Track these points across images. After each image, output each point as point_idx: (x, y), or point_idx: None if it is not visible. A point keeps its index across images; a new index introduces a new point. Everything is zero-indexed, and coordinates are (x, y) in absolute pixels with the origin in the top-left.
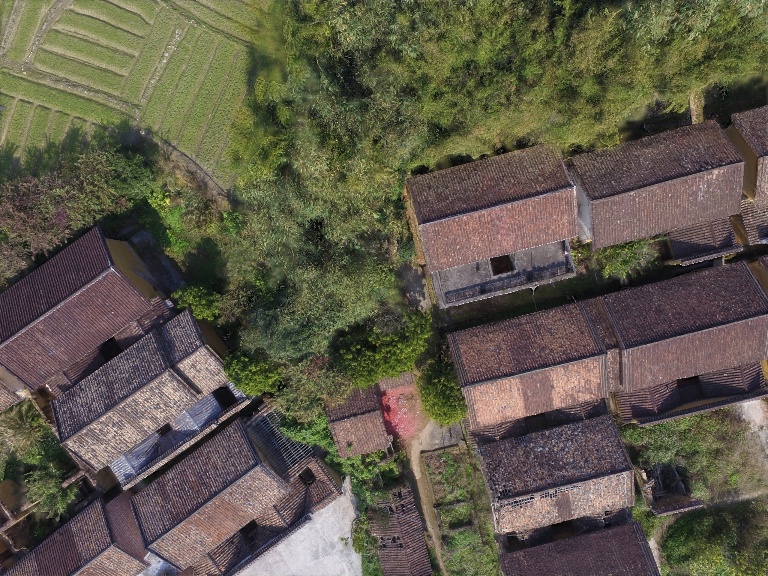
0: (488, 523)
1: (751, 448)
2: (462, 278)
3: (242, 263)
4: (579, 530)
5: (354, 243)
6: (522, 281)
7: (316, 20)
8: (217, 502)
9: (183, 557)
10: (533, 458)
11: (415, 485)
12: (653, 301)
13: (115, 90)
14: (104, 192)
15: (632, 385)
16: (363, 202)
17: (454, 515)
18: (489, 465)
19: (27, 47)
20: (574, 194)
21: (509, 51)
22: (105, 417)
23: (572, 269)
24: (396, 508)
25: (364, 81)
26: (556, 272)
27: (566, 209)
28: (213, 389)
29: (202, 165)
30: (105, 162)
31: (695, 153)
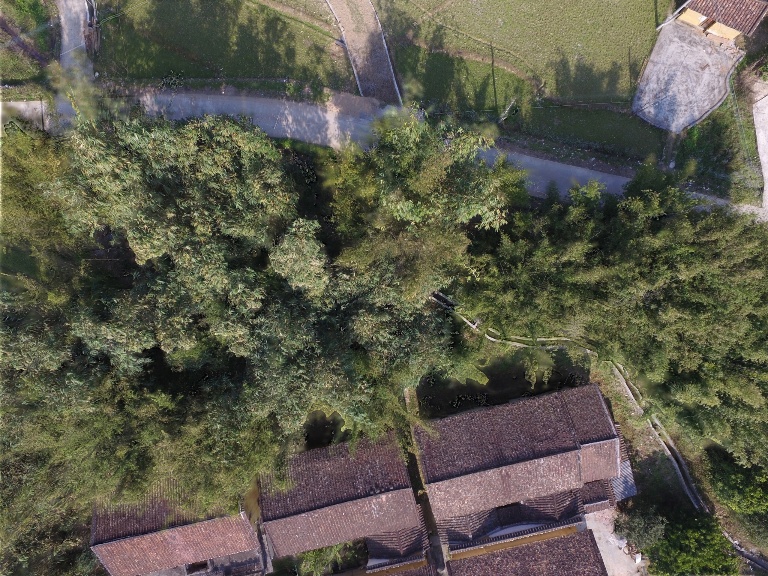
0: None
1: None
2: (161, 571)
3: None
4: None
5: None
6: (220, 575)
7: None
8: None
9: None
10: None
11: None
12: None
13: None
14: None
15: None
16: None
17: None
18: None
19: None
20: (242, 518)
21: (123, 432)
22: None
23: (263, 571)
24: None
25: None
26: (253, 568)
27: (239, 529)
28: None
29: None
30: None
31: (370, 471)
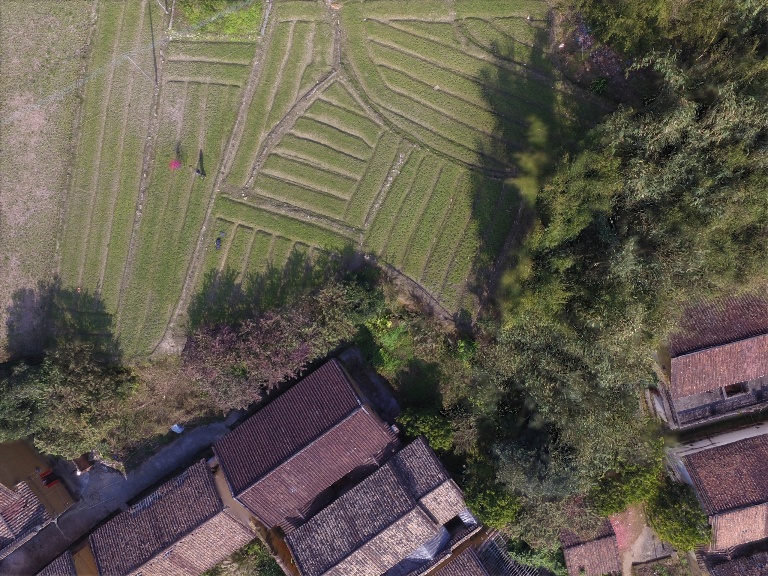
0: None
1: None
2: (692, 398)
3: (454, 380)
4: None
5: (635, 391)
6: (752, 400)
7: (612, 177)
8: None
9: None
10: None
11: None
12: None
13: (338, 215)
14: (342, 325)
15: None
16: None
17: None
18: None
19: (247, 172)
20: None
21: None
22: (350, 556)
23: None
24: None
25: (660, 237)
26: None
27: None
28: (449, 519)
29: (428, 289)
30: (345, 295)
31: None
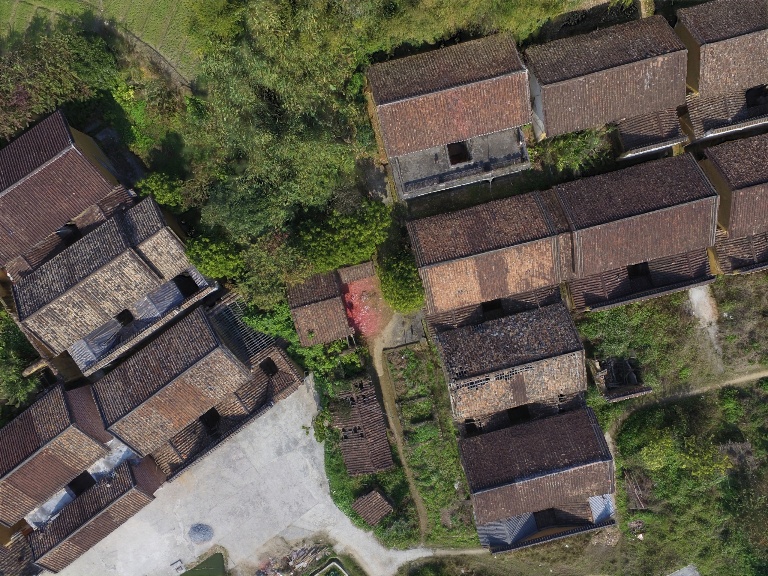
0: (449, 420)
1: (701, 343)
2: (421, 169)
3: (207, 160)
4: (534, 417)
5: (310, 110)
6: (479, 172)
7: None
8: (178, 384)
9: (144, 442)
10: (489, 342)
11: (377, 382)
12: (604, 189)
13: None
14: (66, 75)
15: (584, 270)
16: (319, 70)
17: (415, 411)
18: (446, 350)
19: None
20: (526, 78)
21: None
22: (65, 297)
23: None
24: (357, 398)
25: None
26: (512, 163)
27: (519, 94)
28: (175, 275)
29: (166, 56)
30: (67, 45)
31: (642, 43)
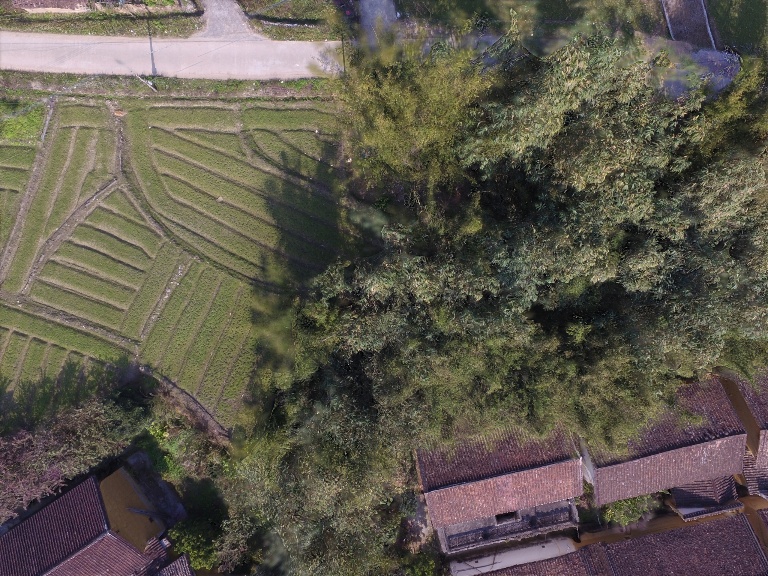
0: None
1: None
2: (465, 522)
3: (241, 488)
4: None
5: (360, 538)
6: (525, 526)
7: (327, 331)
8: None
9: None
10: None
11: None
12: (655, 555)
13: (114, 325)
14: (101, 444)
15: None
16: None
17: None
18: None
19: (23, 278)
20: (580, 464)
21: (521, 368)
22: None
23: (576, 520)
24: None
25: (374, 392)
26: (559, 518)
27: (572, 475)
28: None
29: (203, 403)
30: (103, 415)
31: None
